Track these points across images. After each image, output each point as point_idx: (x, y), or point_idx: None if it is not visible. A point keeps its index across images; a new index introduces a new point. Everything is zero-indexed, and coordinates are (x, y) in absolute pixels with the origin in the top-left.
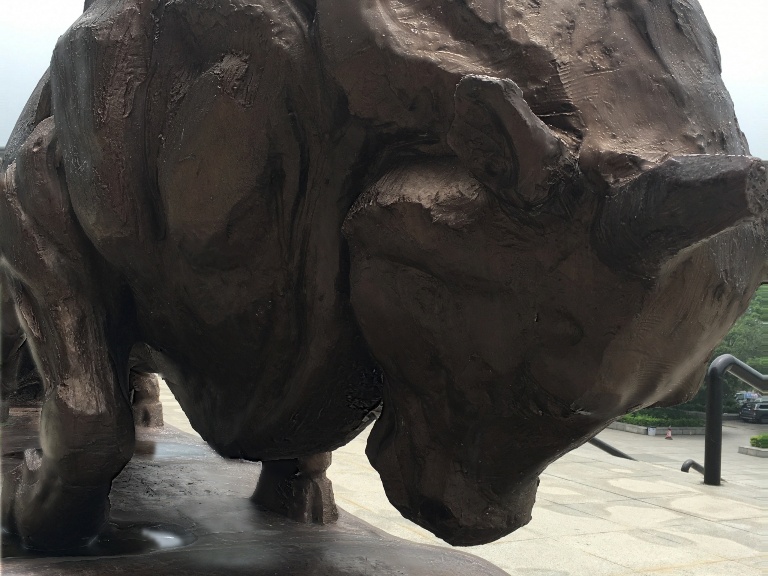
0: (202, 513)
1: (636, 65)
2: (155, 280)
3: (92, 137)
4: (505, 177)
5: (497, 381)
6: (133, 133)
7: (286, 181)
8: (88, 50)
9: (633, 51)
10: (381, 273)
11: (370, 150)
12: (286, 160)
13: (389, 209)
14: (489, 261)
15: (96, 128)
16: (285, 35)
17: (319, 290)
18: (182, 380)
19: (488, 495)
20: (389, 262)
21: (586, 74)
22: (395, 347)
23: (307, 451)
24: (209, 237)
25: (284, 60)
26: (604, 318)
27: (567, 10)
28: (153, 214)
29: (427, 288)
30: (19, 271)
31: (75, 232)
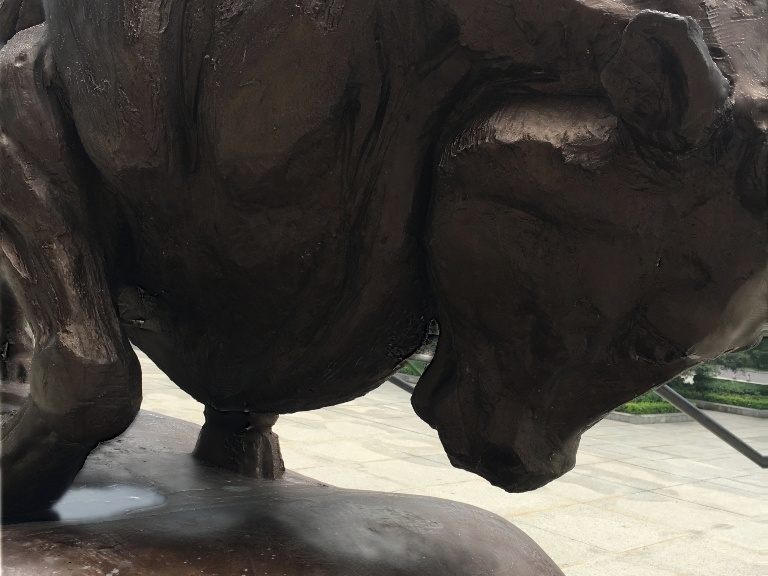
0: (153, 471)
1: None
2: (178, 217)
3: (120, 53)
4: (659, 119)
5: (603, 326)
6: (168, 52)
7: (360, 114)
8: None
9: None
10: (479, 214)
11: (466, 85)
12: (364, 91)
13: (511, 147)
14: (619, 204)
15: (128, 43)
16: None
17: (383, 232)
18: (169, 328)
19: (553, 441)
20: (491, 203)
21: (732, 20)
22: (479, 292)
23: (325, 402)
24: (265, 171)
25: None
26: (738, 264)
27: None
28: (185, 144)
29: (530, 231)
30: (2, 203)
31: (71, 161)
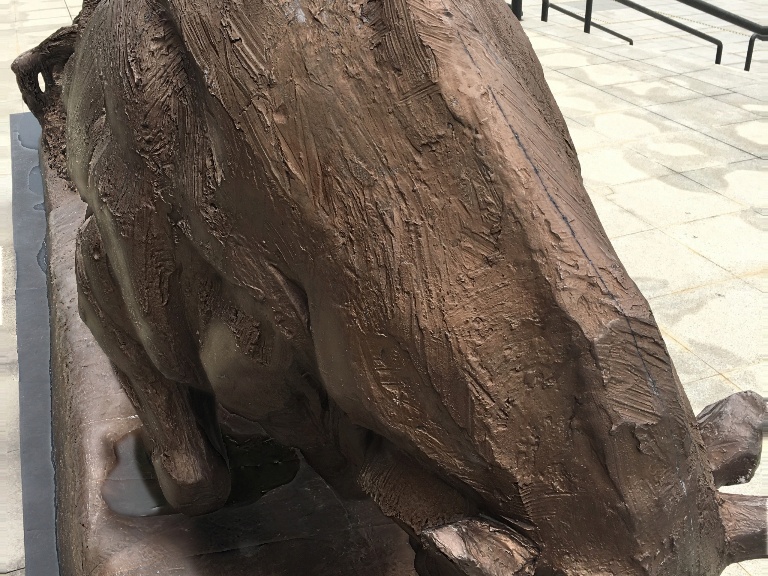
0: None
1: (593, 493)
2: None
3: None
4: None
5: None
6: (174, 314)
7: (311, 403)
8: (118, 240)
9: (591, 479)
10: None
11: None
12: (307, 395)
13: None
14: None
15: (141, 316)
16: (287, 325)
17: (353, 461)
18: None
19: None
20: None
21: (546, 495)
22: None
23: None
24: (255, 419)
25: (290, 345)
26: None
27: (533, 424)
28: None
29: None
30: None
31: None
